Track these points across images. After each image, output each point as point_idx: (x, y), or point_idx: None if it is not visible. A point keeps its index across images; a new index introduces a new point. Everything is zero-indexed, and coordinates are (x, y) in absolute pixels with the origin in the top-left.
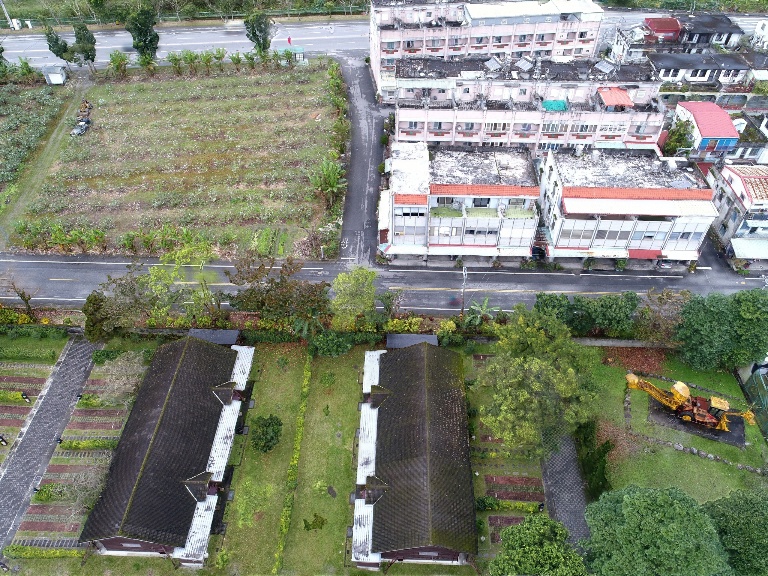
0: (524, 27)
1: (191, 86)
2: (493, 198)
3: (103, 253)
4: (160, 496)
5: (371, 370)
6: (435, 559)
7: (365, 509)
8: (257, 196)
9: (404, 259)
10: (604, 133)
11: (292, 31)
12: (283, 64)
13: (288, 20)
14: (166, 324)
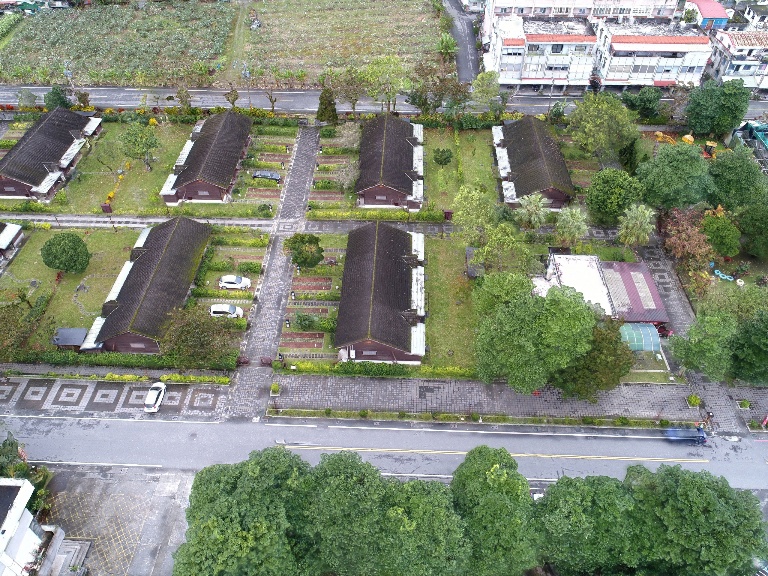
0: None
1: None
2: (565, 45)
3: (303, 88)
4: (395, 174)
5: (497, 134)
6: (550, 207)
7: (509, 184)
8: None
9: None
10: (635, 15)
11: None
12: None
13: None
14: (360, 118)
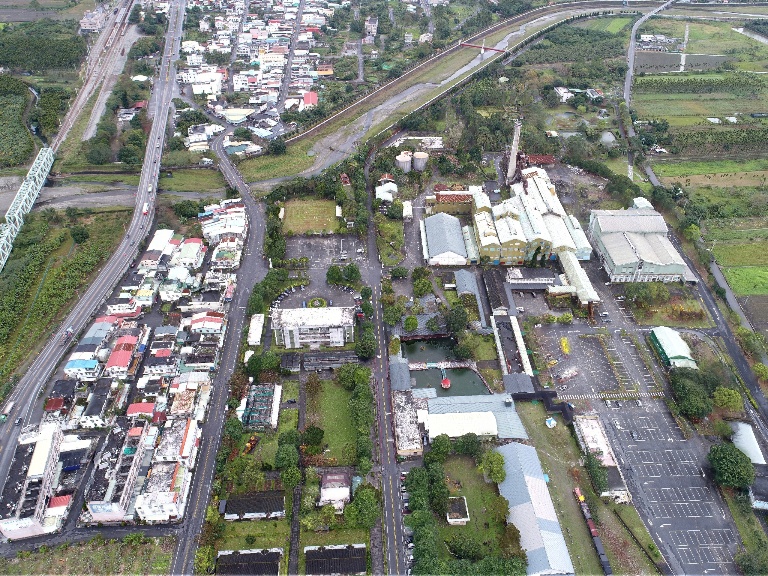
0: None
1: None
2: None
3: None
4: None
5: (232, 517)
6: None
7: (273, 514)
8: (130, 572)
9: None
10: None
11: None
12: None
13: None
14: None
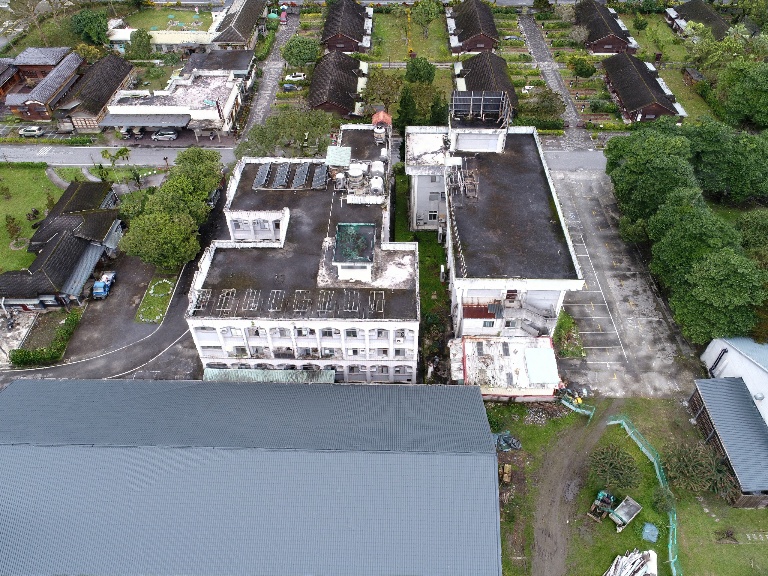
0: None
1: None
2: None
3: None
4: None
5: (672, 12)
6: None
7: None
8: None
9: None
10: None
11: None
12: None
13: None
14: None
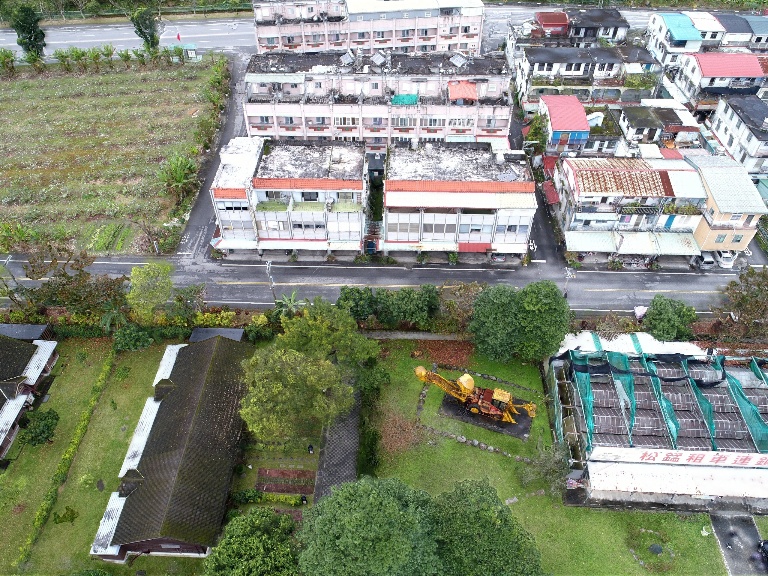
0: (404, 22)
1: (77, 83)
2: (320, 192)
3: None
4: None
5: (167, 364)
6: (181, 552)
7: (118, 502)
8: (109, 192)
9: (240, 254)
10: (454, 127)
11: (195, 28)
12: (175, 61)
13: (194, 17)
14: None
